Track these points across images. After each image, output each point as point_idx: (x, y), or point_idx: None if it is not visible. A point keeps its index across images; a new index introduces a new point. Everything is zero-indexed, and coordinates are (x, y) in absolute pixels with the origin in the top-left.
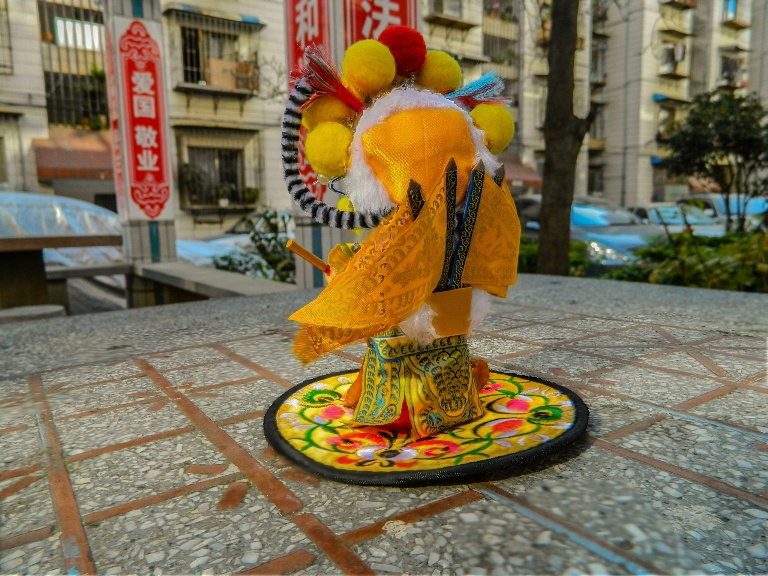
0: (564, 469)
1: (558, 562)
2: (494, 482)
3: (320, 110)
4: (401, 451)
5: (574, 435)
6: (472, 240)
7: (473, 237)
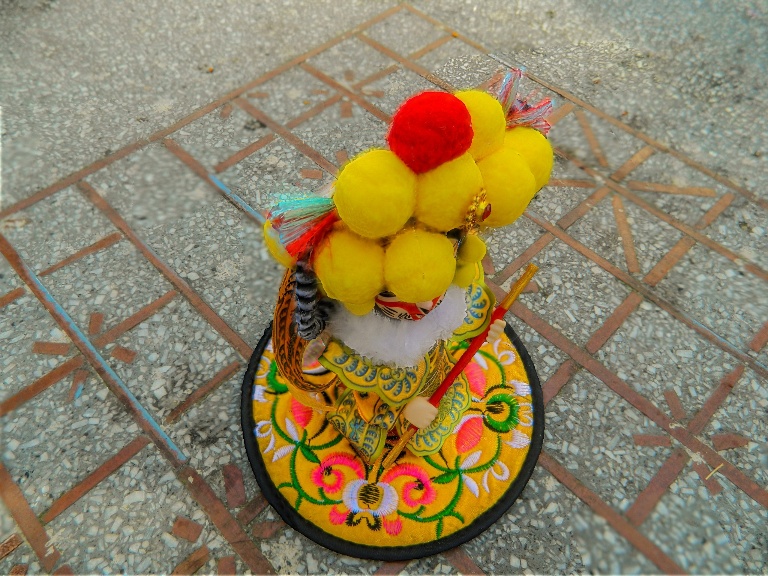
0: None
1: None
2: None
3: None
4: None
5: (271, 321)
6: None
7: None
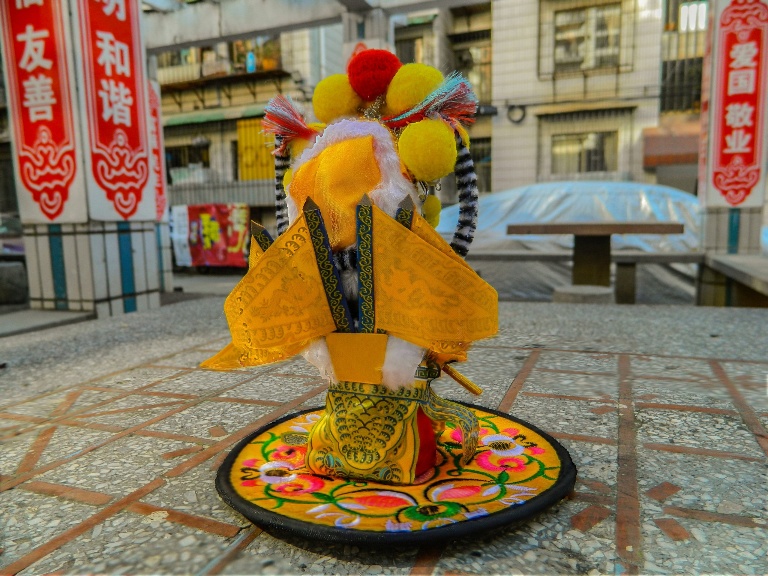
0: (325, 564)
1: None
2: (264, 534)
3: (295, 151)
4: (286, 475)
5: (363, 536)
6: (377, 282)
7: (378, 279)
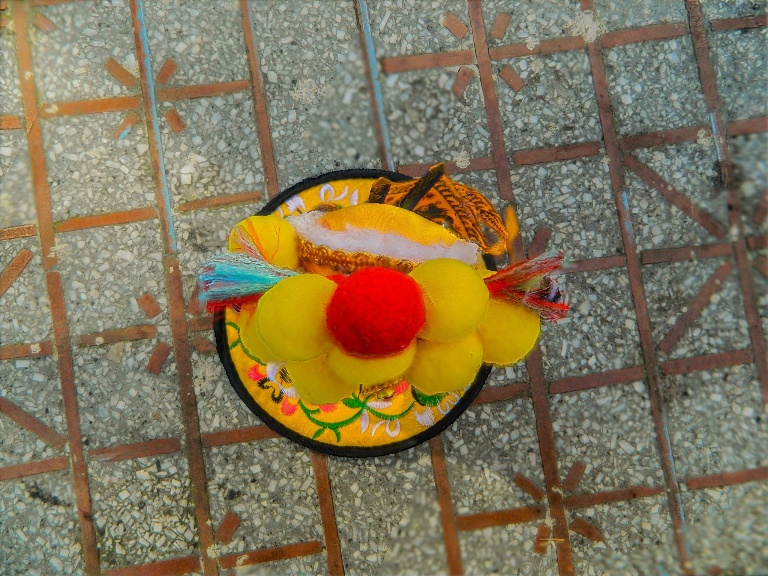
0: None
1: (404, 95)
2: None
3: None
4: None
5: (306, 179)
6: None
7: None
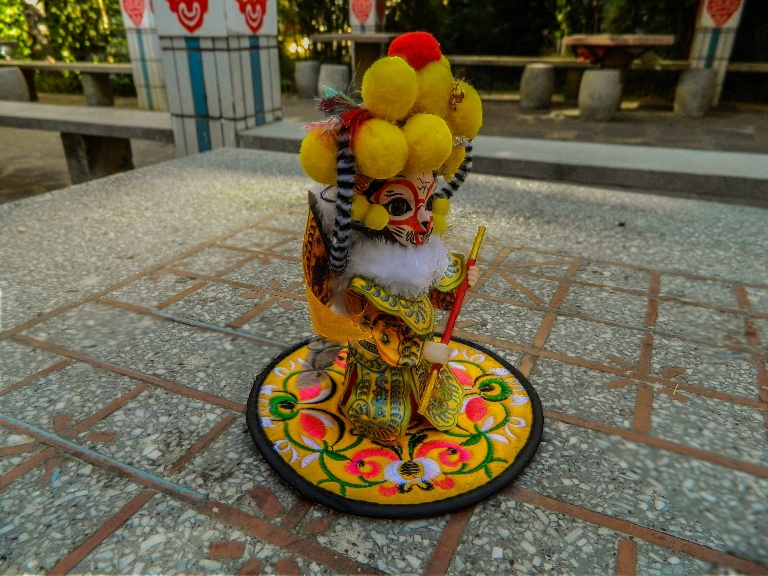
0: None
1: (262, 326)
2: None
3: None
4: None
5: (257, 375)
6: None
7: None
